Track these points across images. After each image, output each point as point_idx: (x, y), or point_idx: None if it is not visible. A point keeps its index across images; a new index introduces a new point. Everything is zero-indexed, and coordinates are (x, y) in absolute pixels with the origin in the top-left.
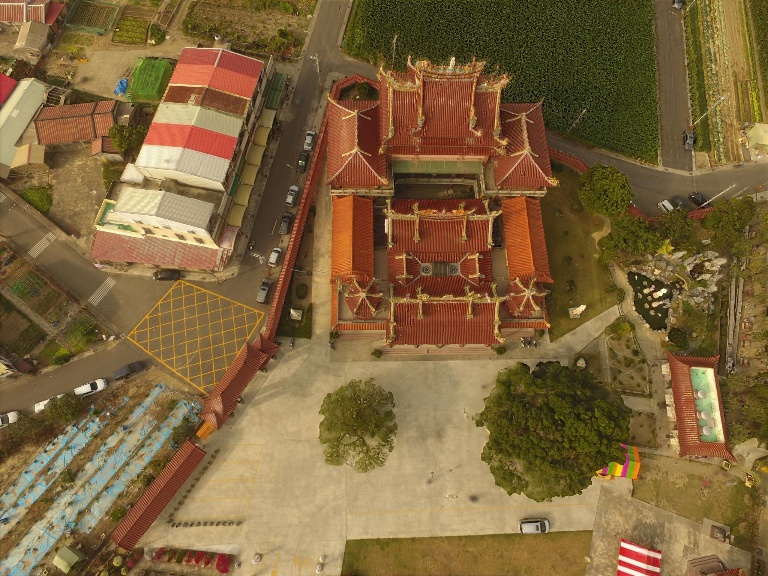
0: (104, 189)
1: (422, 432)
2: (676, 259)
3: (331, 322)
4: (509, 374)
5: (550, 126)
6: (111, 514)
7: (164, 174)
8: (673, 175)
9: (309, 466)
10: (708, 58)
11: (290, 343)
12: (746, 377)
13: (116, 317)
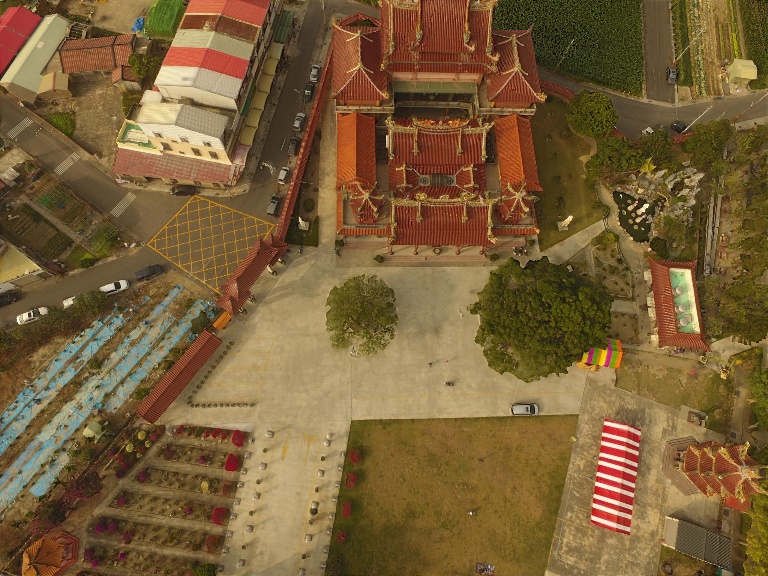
0: (124, 115)
1: (421, 328)
2: (658, 178)
3: (336, 227)
4: (501, 269)
5: (541, 62)
6: (136, 392)
7: (181, 92)
8: (657, 106)
9: (316, 357)
10: (691, 2)
11: (298, 250)
12: (723, 284)
13: (137, 227)
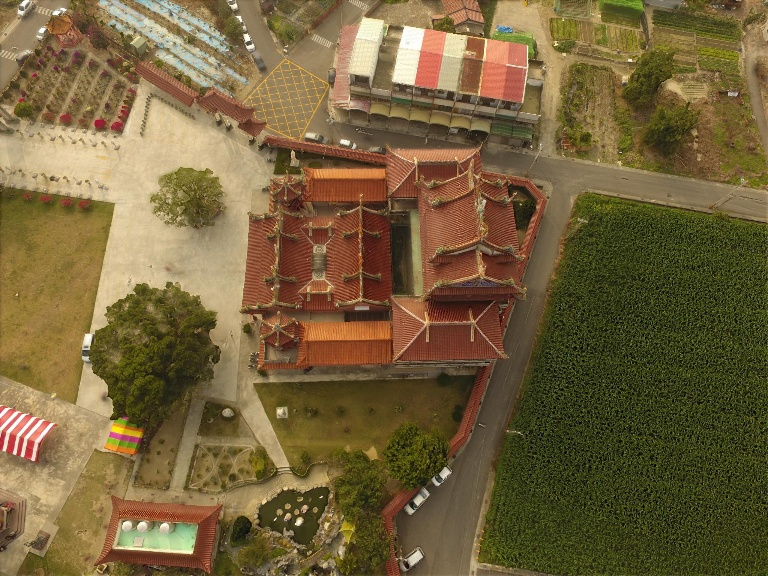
0: None
1: (185, 259)
2: None
3: (278, 178)
4: (208, 312)
5: (517, 414)
6: None
7: None
8: None
9: None
10: None
11: None
12: None
13: (301, 51)
